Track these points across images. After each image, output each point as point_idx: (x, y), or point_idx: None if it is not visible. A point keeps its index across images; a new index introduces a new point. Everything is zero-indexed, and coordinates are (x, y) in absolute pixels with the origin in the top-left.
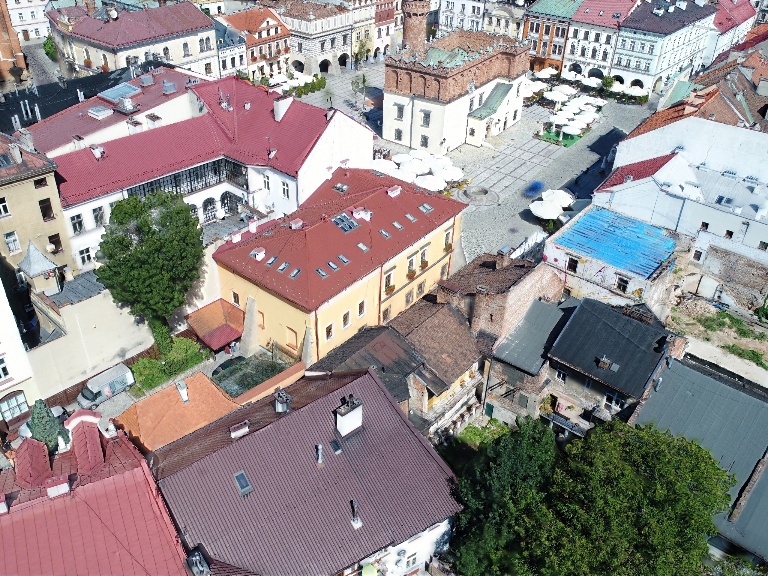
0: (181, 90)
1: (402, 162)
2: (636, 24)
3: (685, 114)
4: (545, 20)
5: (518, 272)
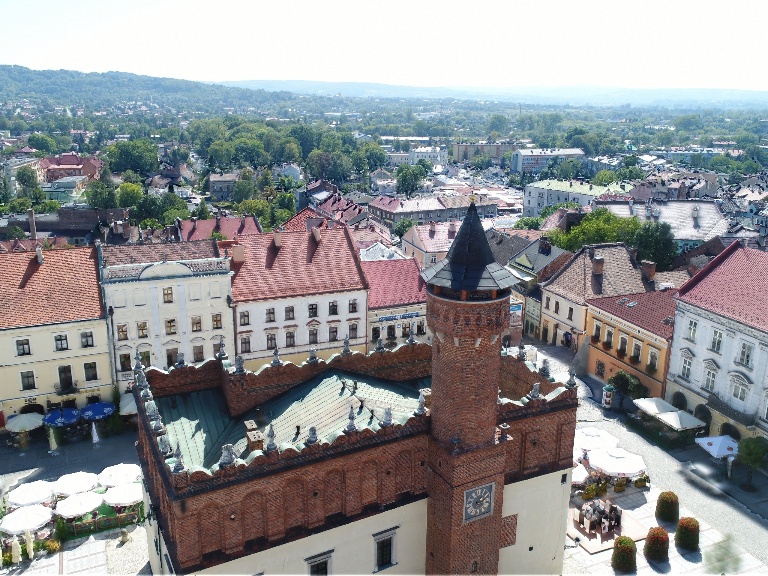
0: None
1: (576, 457)
2: None
3: (321, 239)
4: None
5: (601, 254)
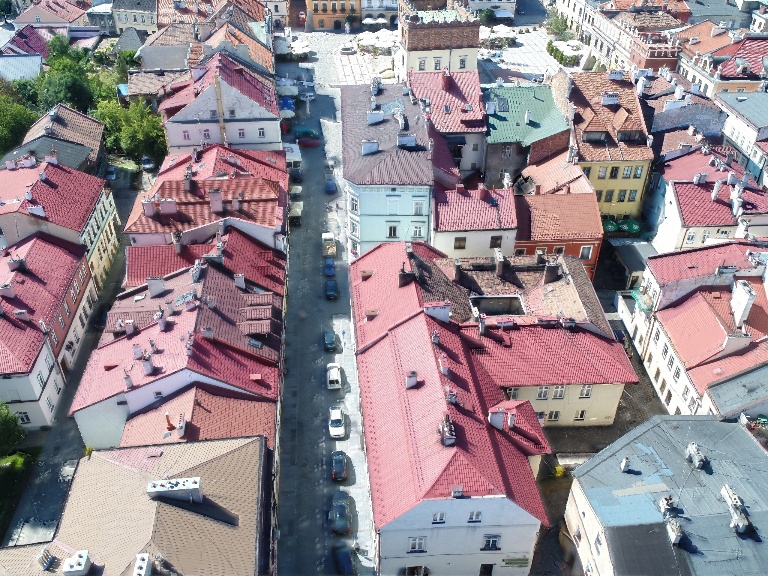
0: None
1: None
2: None
3: None
4: None
5: None
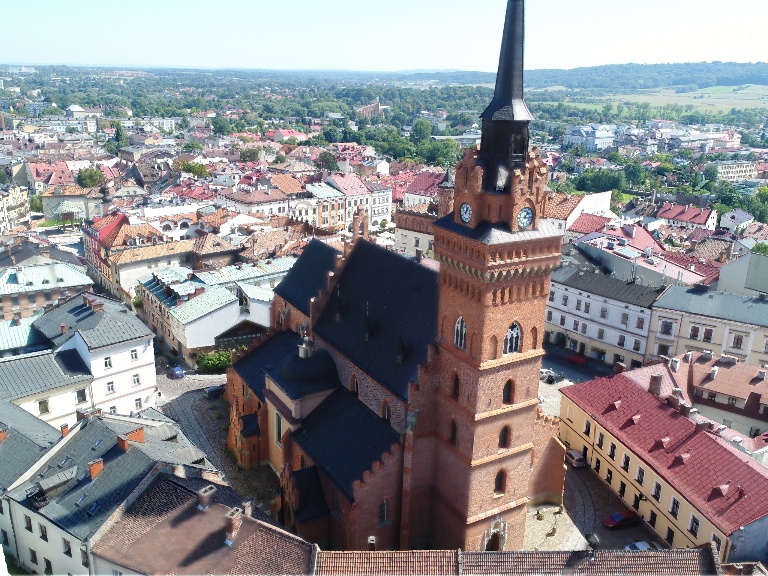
0: (617, 242)
1: None
2: (376, 188)
3: (569, 199)
4: (331, 201)
5: (710, 242)
